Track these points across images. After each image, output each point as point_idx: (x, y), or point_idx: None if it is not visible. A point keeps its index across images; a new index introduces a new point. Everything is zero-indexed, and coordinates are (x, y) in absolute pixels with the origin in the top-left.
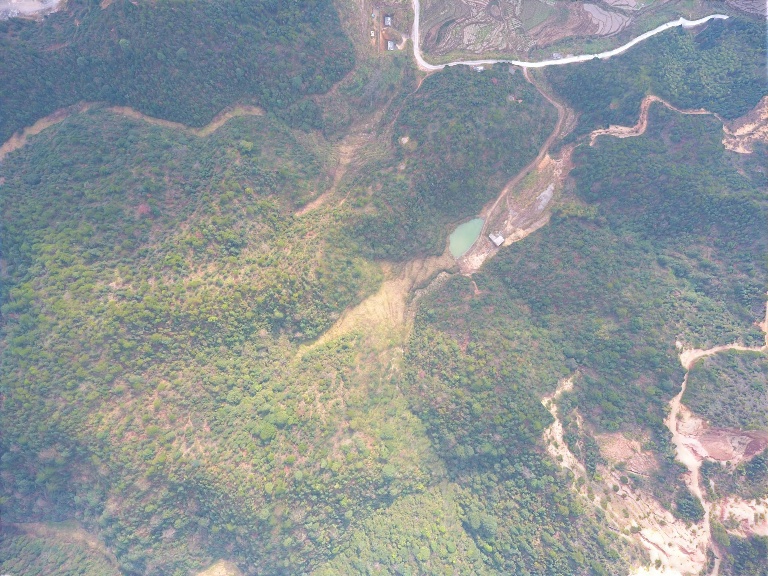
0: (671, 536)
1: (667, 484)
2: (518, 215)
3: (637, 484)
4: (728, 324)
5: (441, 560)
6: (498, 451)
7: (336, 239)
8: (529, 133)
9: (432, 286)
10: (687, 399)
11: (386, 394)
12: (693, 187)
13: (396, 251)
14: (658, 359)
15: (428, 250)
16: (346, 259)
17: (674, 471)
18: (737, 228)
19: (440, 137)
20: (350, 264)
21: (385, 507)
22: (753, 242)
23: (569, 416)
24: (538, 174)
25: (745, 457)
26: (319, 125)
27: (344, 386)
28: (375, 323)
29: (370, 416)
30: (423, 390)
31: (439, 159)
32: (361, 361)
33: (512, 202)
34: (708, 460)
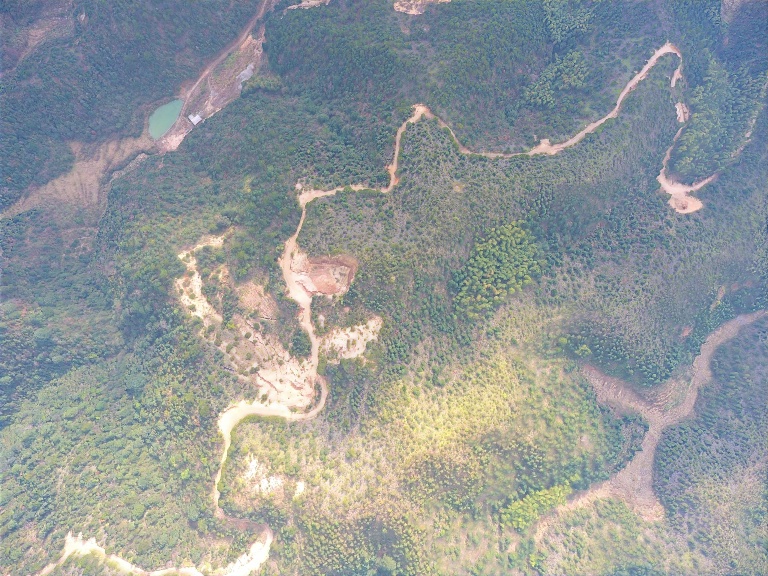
0: (283, 373)
1: (287, 324)
2: (218, 95)
3: (267, 329)
4: (361, 169)
5: (86, 417)
6: (144, 308)
7: (1, 112)
8: (217, 9)
9: (129, 167)
10: (298, 236)
11: (69, 270)
12: (346, 43)
13: (80, 129)
14: (279, 202)
15: (122, 130)
16: (16, 133)
17: (283, 307)
18: (384, 80)
19: (103, 7)
20: (23, 139)
21: (57, 378)
22: (397, 92)
23: (213, 270)
24: (238, 54)
25: (347, 288)
26: (4, 7)
27: (3, 254)
28: (62, 202)
29: (37, 286)
30: (101, 263)
31: (105, 29)
32: (33, 234)
33: (212, 83)
34: (316, 295)
